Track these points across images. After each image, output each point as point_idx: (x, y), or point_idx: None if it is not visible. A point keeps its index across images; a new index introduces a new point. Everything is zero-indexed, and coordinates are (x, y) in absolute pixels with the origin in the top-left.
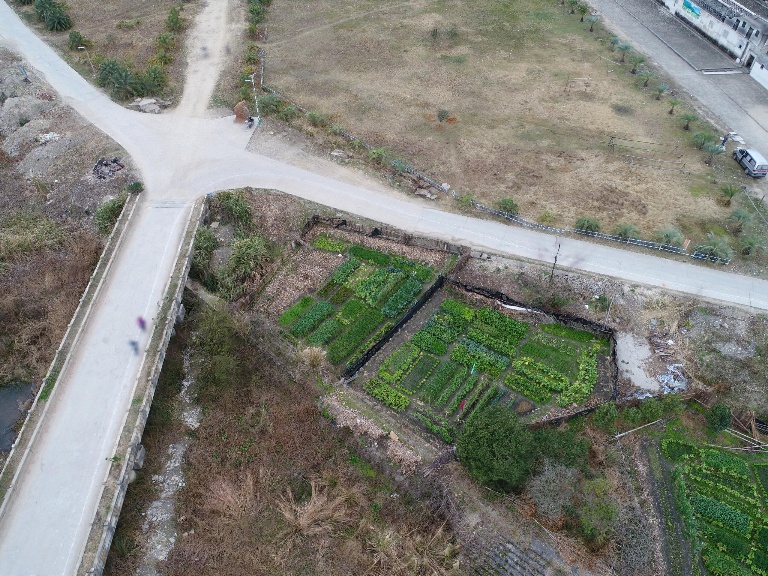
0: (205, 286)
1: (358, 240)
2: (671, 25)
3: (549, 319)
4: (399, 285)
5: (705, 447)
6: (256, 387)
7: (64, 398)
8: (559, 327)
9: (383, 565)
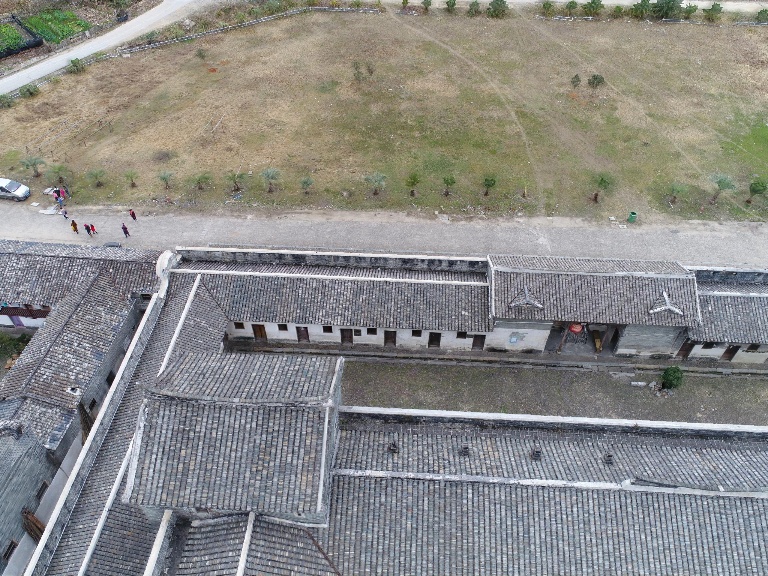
0: None
1: None
2: None
3: None
4: None
5: None
6: None
7: None
8: None
9: None
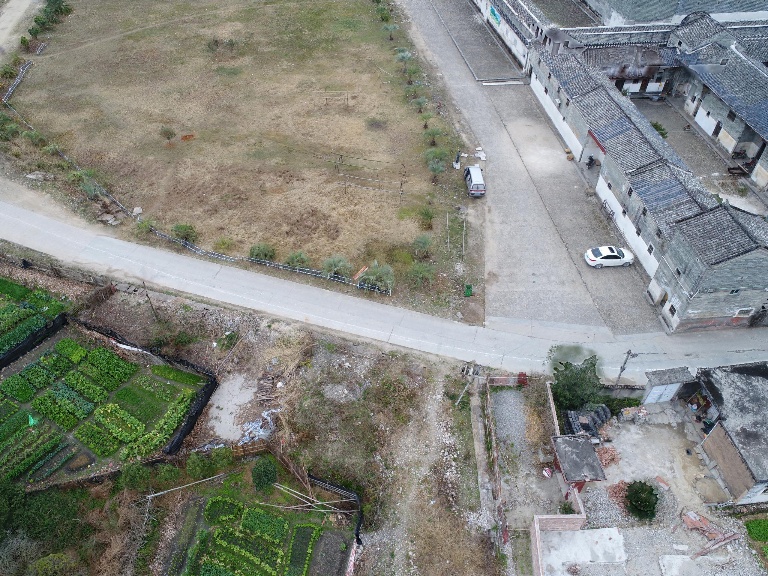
0: None
1: (7, 272)
2: (477, 33)
3: (158, 360)
4: (24, 322)
5: (255, 506)
6: None
7: None
8: (168, 369)
9: None
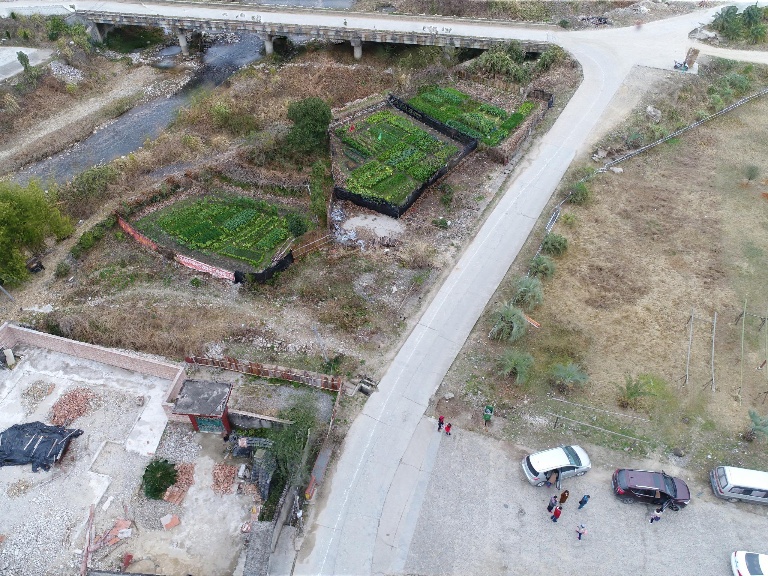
0: None
1: None
2: None
3: None
4: None
5: None
6: None
7: (392, 20)
8: None
9: None
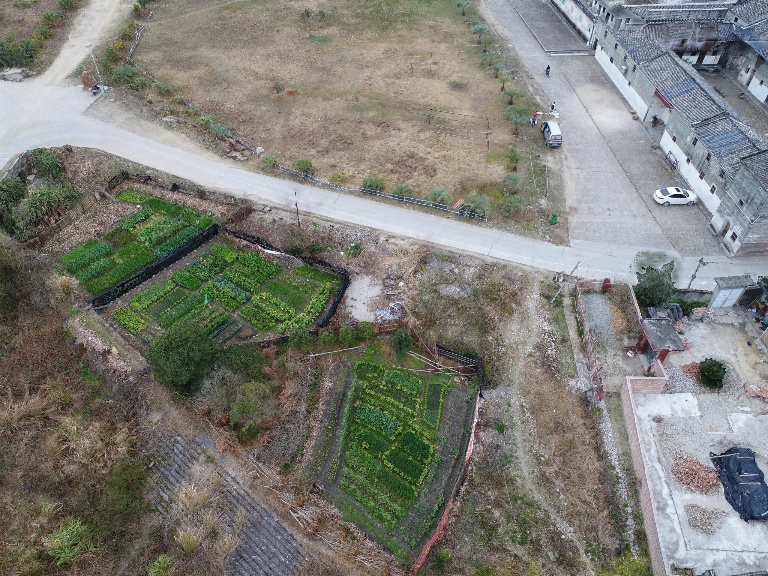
0: (6, 229)
1: (159, 194)
2: (542, 10)
3: (299, 262)
4: (180, 232)
5: (393, 369)
6: (24, 313)
7: None
8: (307, 269)
9: (72, 452)
